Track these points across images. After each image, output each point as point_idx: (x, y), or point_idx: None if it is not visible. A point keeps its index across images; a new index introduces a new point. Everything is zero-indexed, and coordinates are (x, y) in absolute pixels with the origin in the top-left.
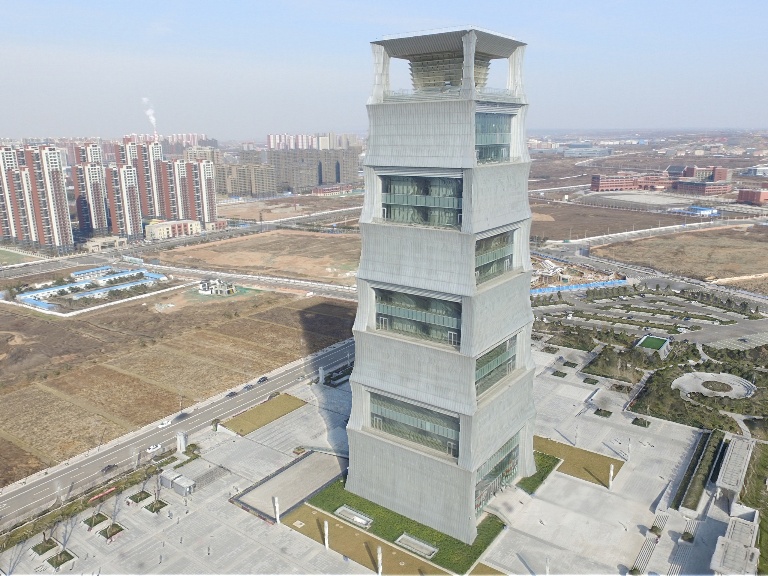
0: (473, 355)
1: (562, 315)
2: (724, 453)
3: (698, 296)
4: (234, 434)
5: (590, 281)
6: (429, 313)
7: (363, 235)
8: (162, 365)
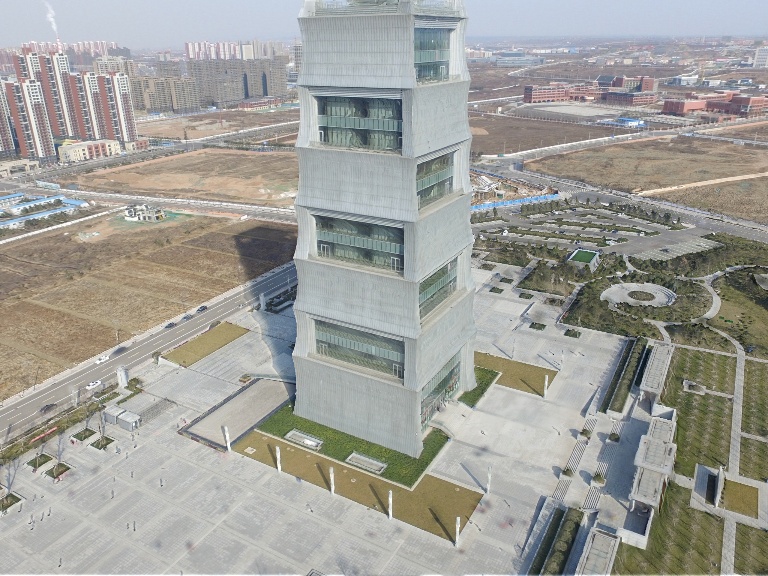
0: (416, 280)
1: (498, 231)
2: (647, 359)
3: (625, 209)
4: (177, 366)
5: (524, 196)
6: (371, 239)
7: (300, 160)
8: (93, 298)
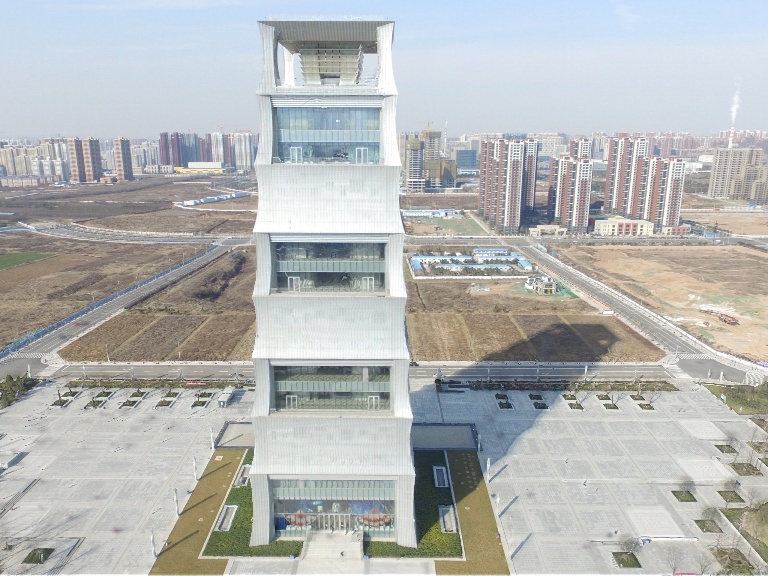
0: (254, 356)
1: None
2: None
3: None
4: None
5: None
6: None
7: None
8: None
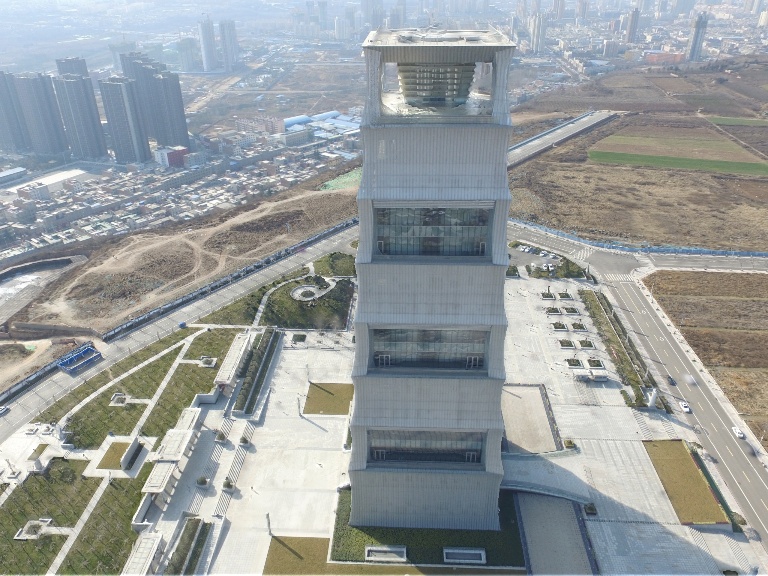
0: None
1: None
2: None
3: None
4: None
5: None
6: None
7: None
8: None
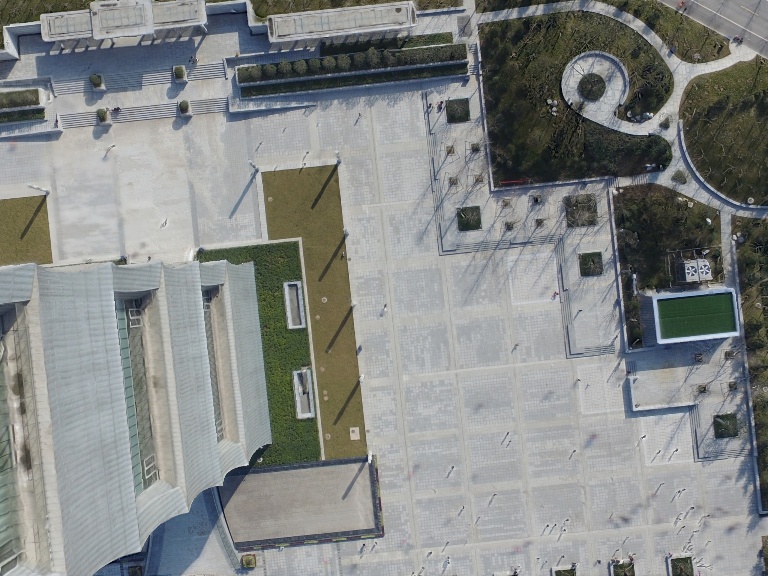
0: (158, 263)
1: None
2: None
3: None
4: None
5: None
6: None
7: None
8: None
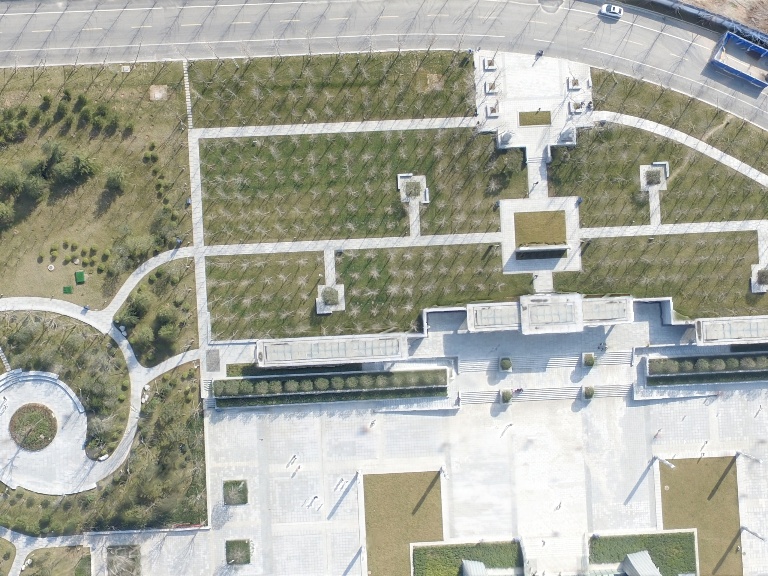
0: None
1: None
2: None
3: None
4: None
5: None
6: None
7: None
8: None
